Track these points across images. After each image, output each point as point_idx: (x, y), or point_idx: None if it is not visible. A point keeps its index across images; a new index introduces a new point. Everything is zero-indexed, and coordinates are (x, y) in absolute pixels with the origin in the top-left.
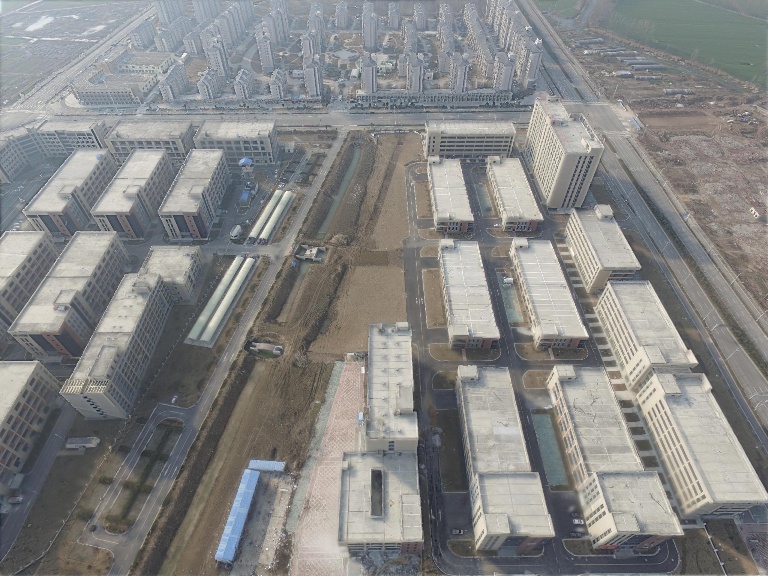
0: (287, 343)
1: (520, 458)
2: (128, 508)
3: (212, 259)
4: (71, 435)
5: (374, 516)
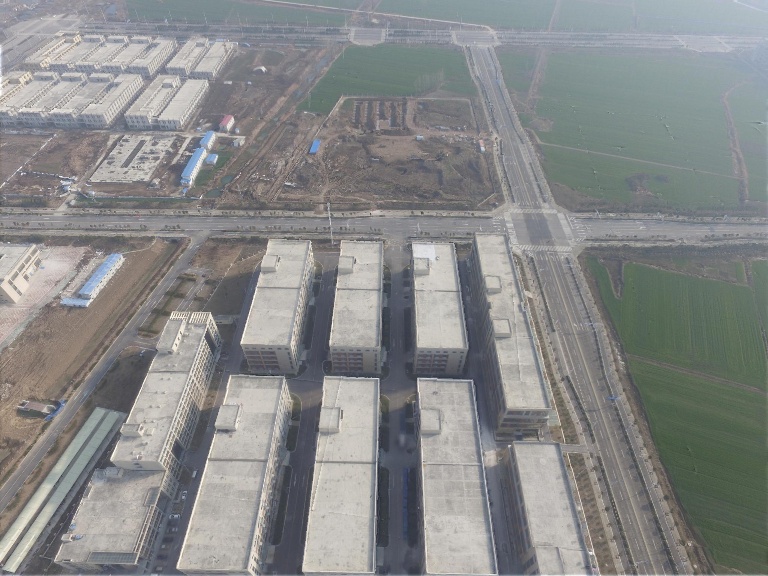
0: (10, 413)
1: None
2: (181, 283)
3: (59, 575)
4: (232, 328)
5: (3, 254)
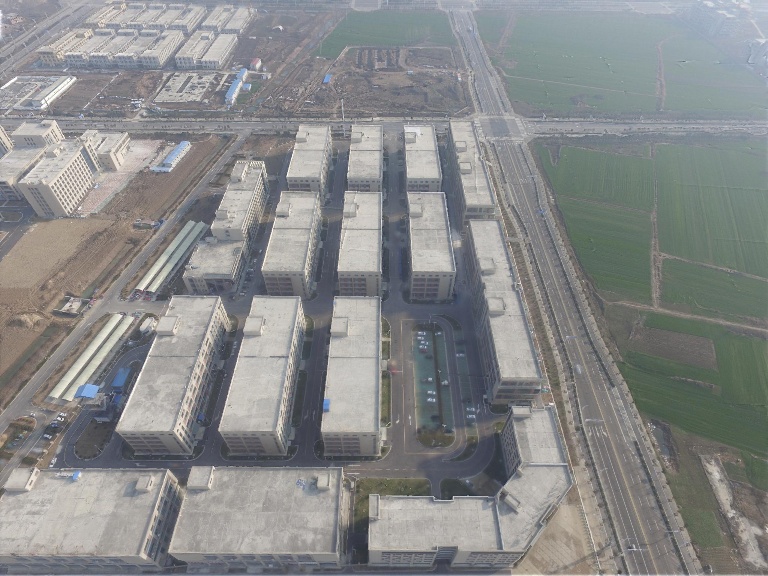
0: (129, 226)
1: (15, 152)
2: None
3: None
4: (276, 182)
5: (106, 137)
